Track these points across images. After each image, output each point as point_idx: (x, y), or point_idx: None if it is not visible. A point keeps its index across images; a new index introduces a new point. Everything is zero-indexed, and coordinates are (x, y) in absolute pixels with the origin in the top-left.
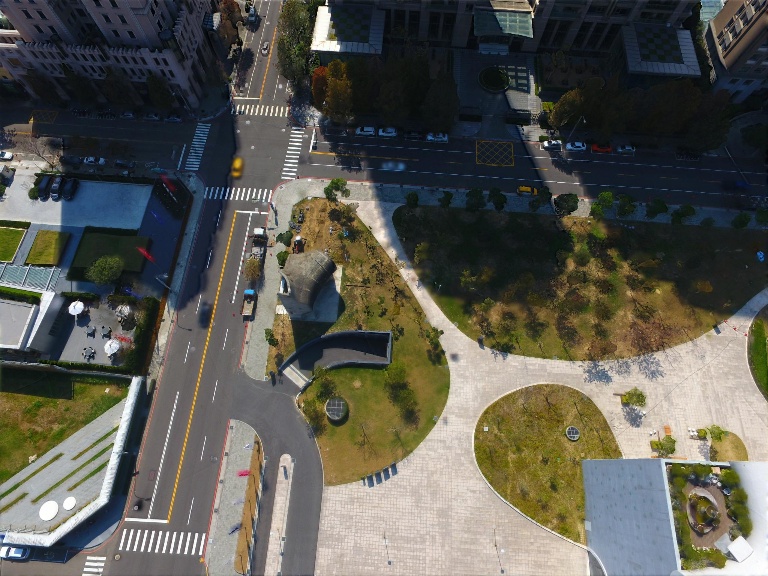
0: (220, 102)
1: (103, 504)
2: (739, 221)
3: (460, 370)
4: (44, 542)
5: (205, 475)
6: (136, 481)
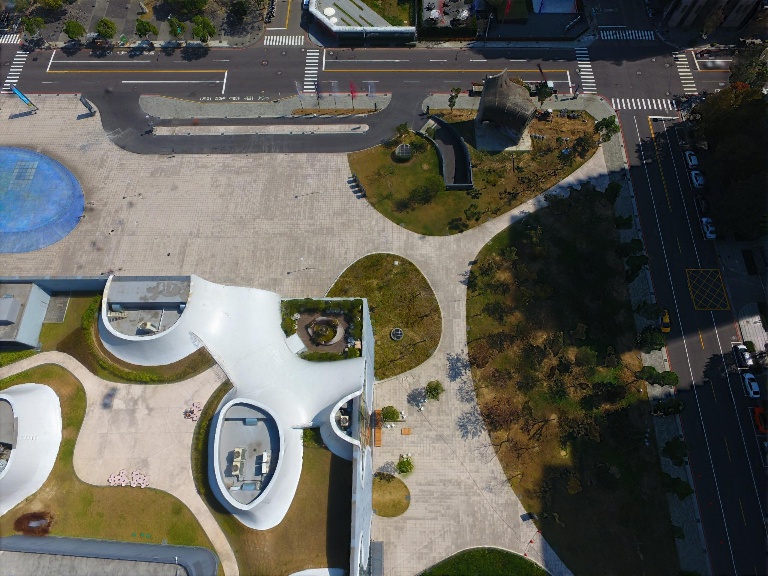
0: (683, 42)
1: (333, 29)
2: (689, 573)
3: (446, 244)
4: (311, 7)
5: (353, 85)
6: (348, 50)
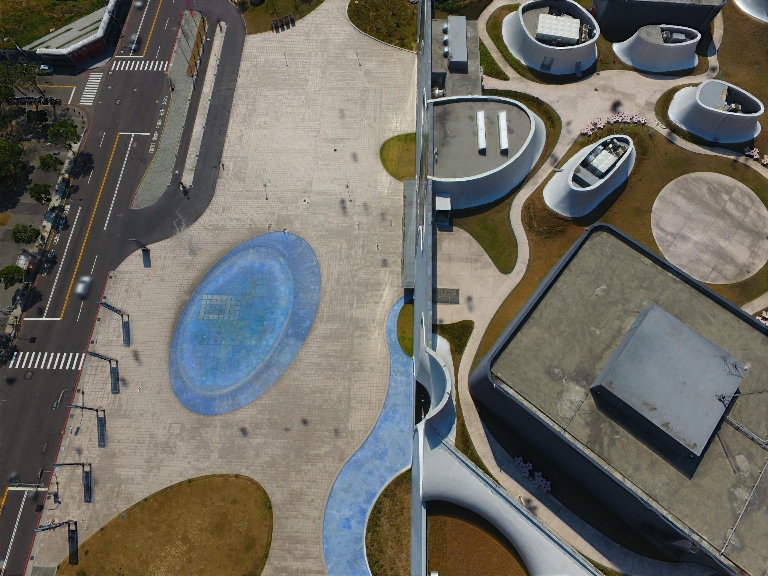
0: None
1: (100, 36)
2: None
3: None
4: (62, 52)
5: (168, 36)
6: (122, 40)
